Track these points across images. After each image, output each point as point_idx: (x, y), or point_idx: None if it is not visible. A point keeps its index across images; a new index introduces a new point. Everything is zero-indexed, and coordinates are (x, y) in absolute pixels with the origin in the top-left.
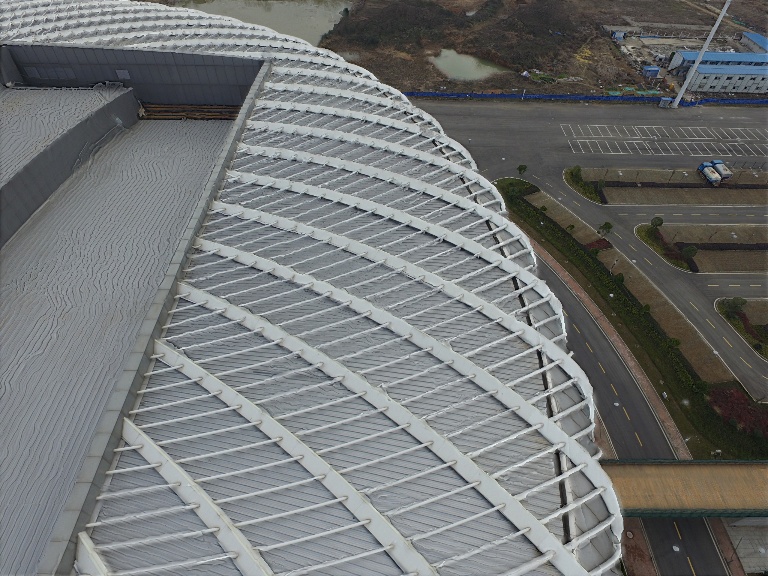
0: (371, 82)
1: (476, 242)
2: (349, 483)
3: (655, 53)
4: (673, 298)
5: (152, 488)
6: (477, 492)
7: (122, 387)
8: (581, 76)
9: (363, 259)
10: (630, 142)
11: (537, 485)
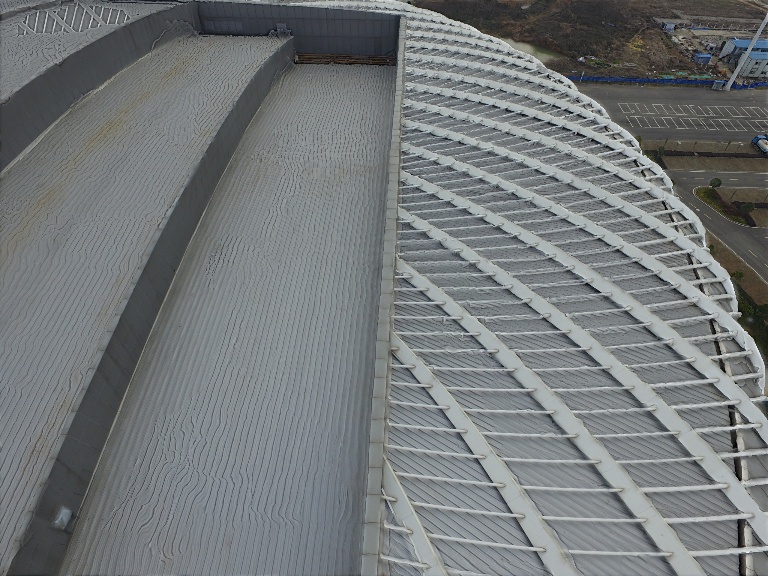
0: (485, 35)
1: (603, 135)
2: (557, 247)
3: (705, 43)
4: (732, 246)
5: (429, 240)
6: (640, 264)
7: (392, 189)
8: (635, 62)
9: (522, 139)
10: (685, 119)
11: (680, 266)
